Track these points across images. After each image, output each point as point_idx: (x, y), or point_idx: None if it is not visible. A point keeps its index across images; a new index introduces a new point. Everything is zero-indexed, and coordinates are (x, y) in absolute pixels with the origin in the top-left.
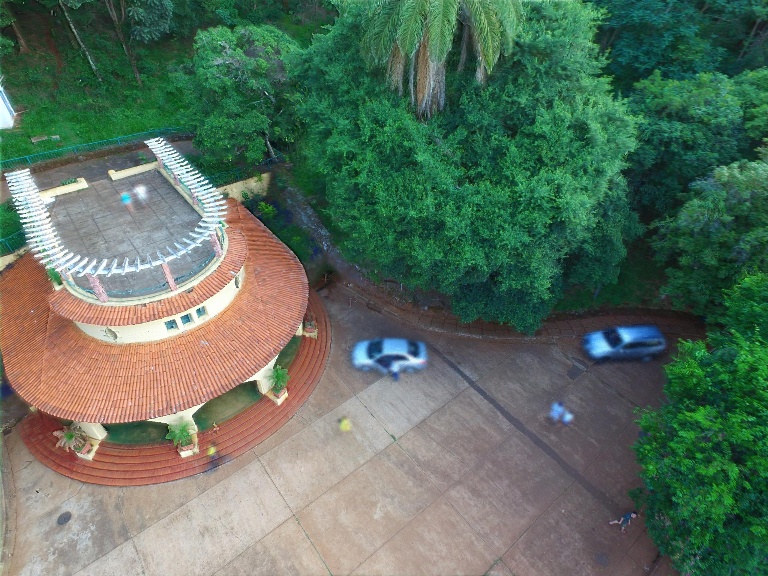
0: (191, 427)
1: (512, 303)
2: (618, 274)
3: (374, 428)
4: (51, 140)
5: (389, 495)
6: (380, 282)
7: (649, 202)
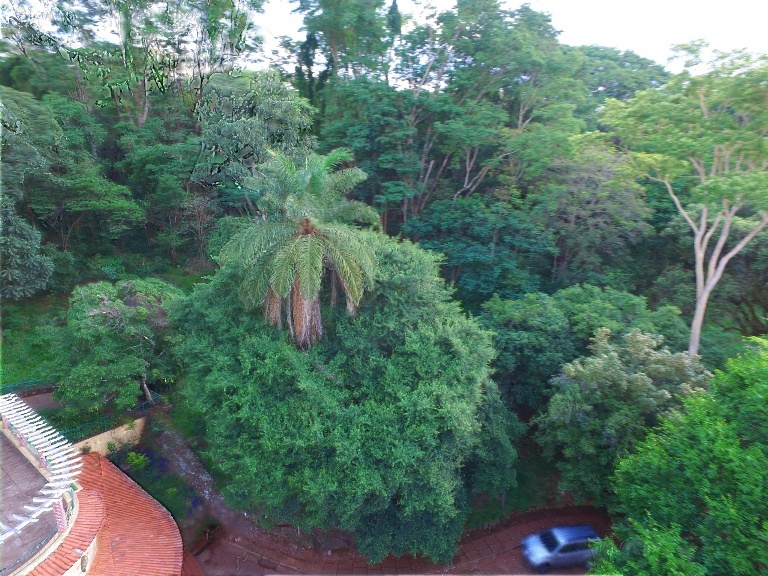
0: None
1: (421, 528)
2: (515, 476)
3: None
4: None
5: None
6: (273, 529)
7: (522, 401)
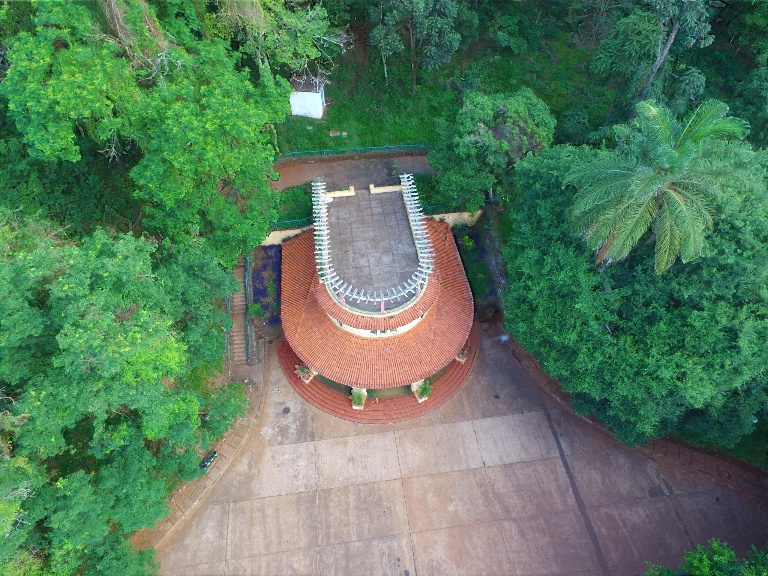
0: (364, 397)
1: None
2: None
3: (474, 450)
4: (342, 137)
5: (463, 500)
6: None
7: None
